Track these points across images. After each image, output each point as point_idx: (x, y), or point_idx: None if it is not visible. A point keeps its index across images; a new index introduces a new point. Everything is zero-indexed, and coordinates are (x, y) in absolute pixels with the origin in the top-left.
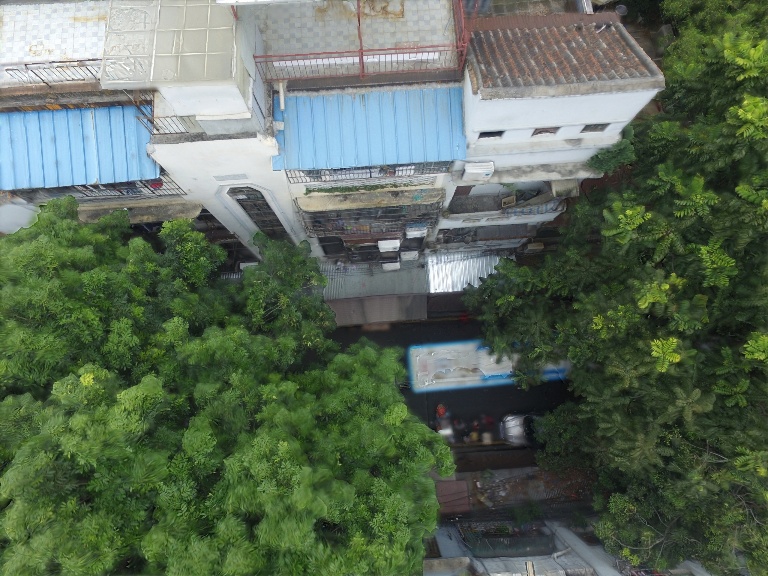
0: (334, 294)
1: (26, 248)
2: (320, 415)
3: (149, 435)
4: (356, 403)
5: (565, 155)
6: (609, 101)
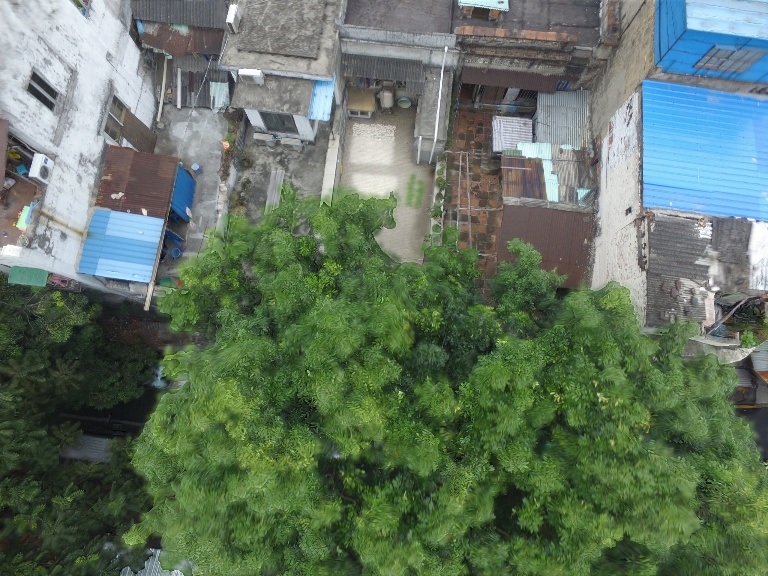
0: None
1: None
2: None
3: None
4: None
5: None
6: None
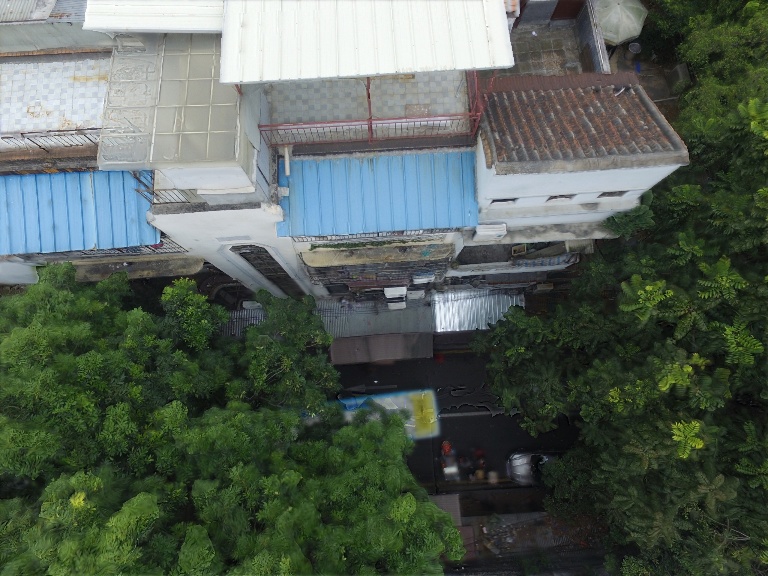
0: (338, 333)
1: (18, 337)
2: (324, 502)
3: (144, 545)
4: (362, 486)
5: (580, 217)
6: (629, 173)
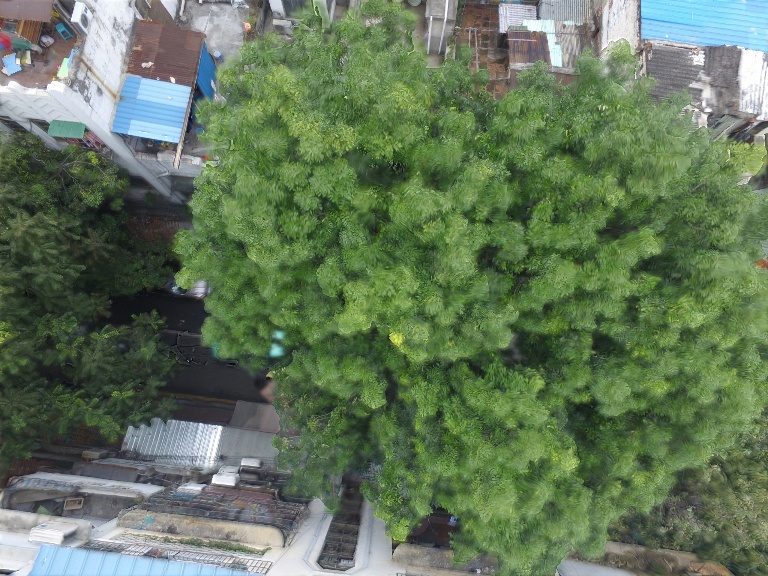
0: None
1: (496, 506)
2: None
3: None
4: (238, 300)
5: None
6: None
